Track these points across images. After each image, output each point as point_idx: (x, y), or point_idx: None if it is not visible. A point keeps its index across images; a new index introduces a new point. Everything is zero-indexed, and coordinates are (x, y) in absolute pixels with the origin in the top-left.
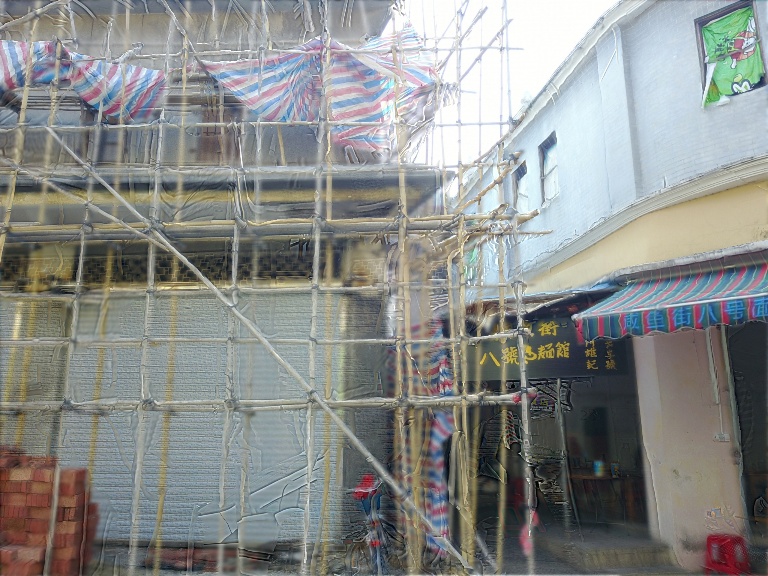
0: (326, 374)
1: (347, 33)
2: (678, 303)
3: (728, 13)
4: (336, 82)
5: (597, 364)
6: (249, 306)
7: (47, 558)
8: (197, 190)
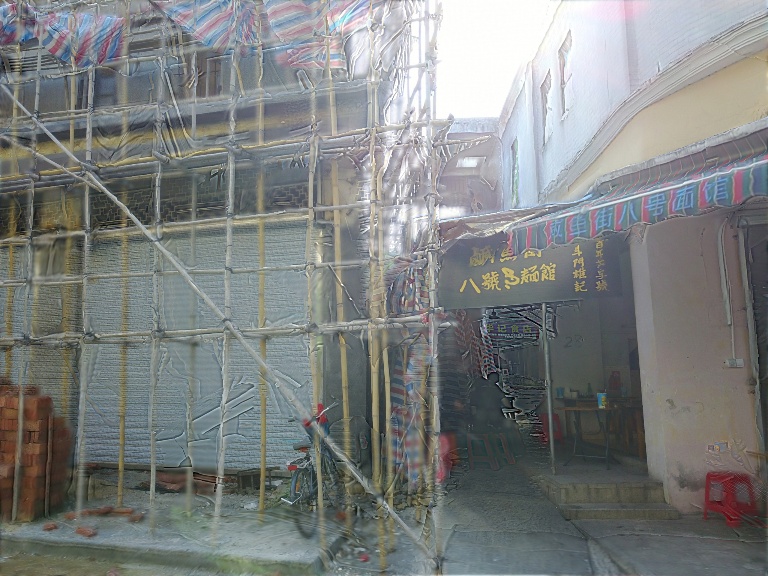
0: (256, 304)
1: None
2: (602, 203)
3: None
4: (275, 3)
5: (586, 286)
6: (172, 240)
7: (17, 475)
8: (128, 130)
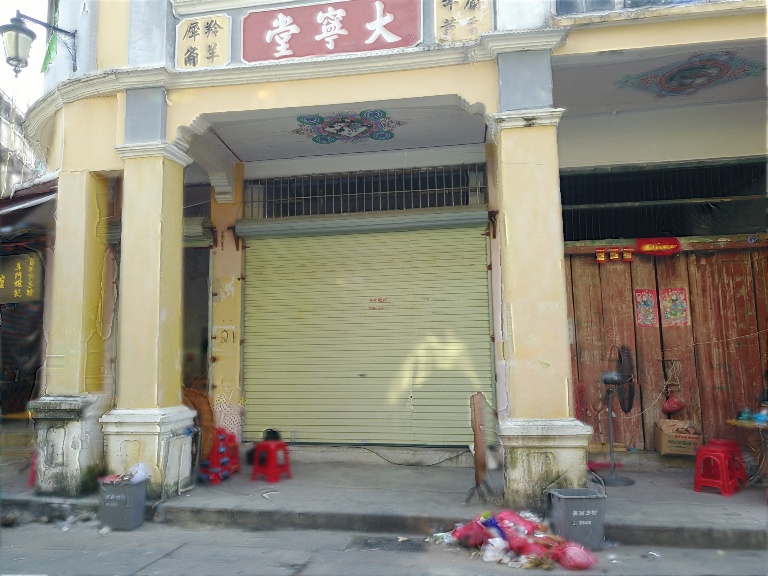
0: None
1: None
2: None
3: None
4: None
5: (21, 293)
6: None
7: None
8: None
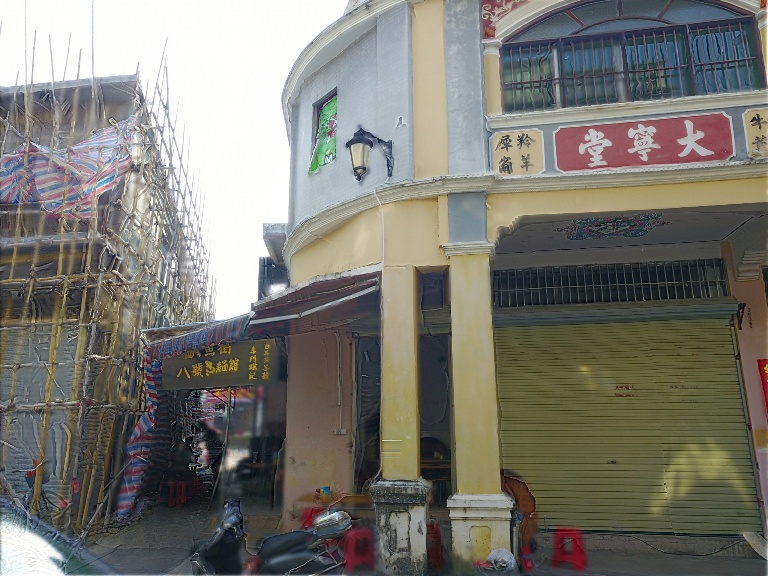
0: None
1: (103, 122)
2: (179, 335)
3: (330, 99)
4: (39, 174)
5: (256, 375)
6: None
7: None
8: None
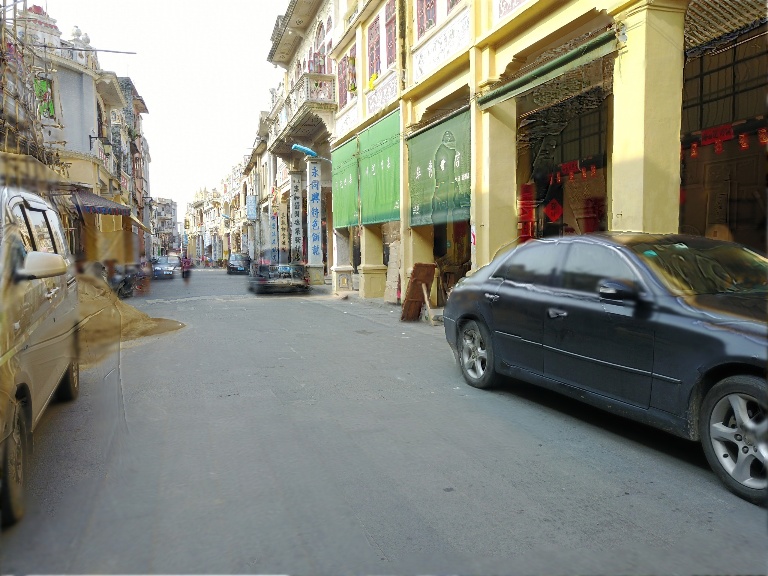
0: None
1: None
2: (85, 205)
3: None
4: None
5: None
6: None
7: None
8: None
